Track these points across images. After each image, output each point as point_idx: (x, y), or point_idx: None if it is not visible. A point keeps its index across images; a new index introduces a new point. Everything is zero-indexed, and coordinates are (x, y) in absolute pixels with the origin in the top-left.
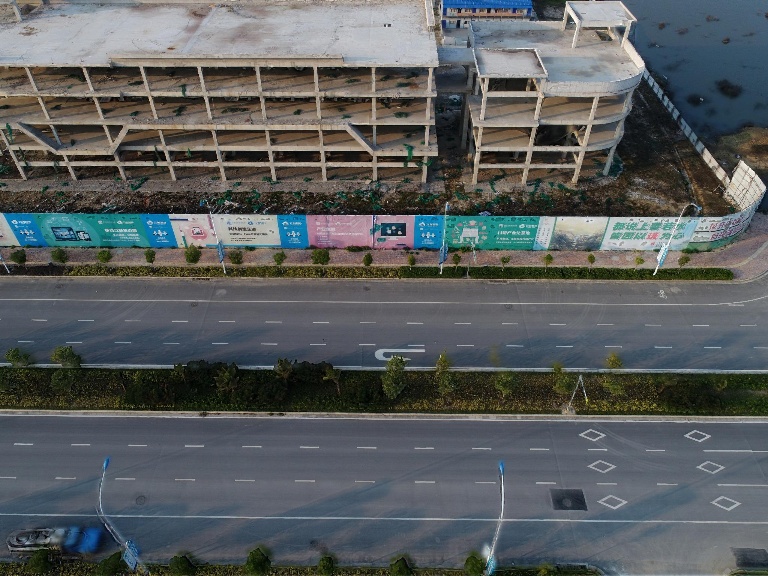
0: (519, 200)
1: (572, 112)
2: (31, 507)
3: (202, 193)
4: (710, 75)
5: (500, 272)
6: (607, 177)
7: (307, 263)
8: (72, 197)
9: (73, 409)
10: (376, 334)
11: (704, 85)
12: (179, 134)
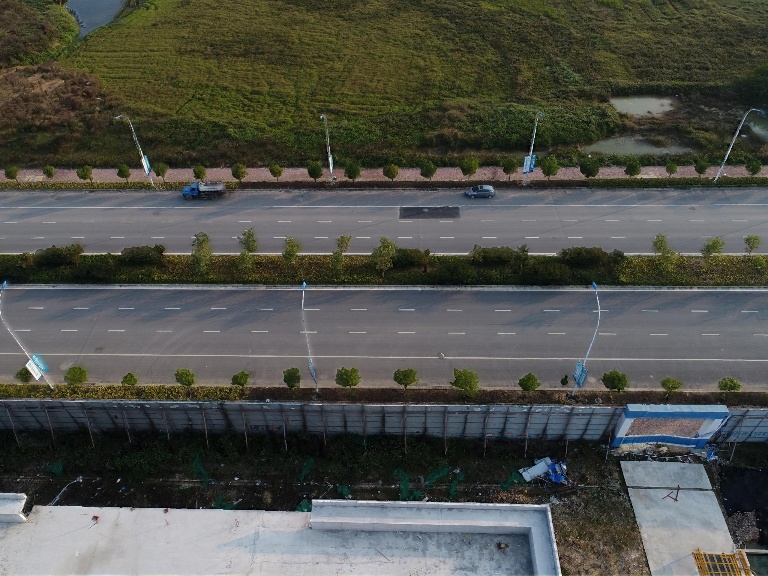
0: None
1: None
2: (223, 210)
3: None
4: None
5: None
6: None
7: None
8: None
9: None
10: None
11: None
12: None
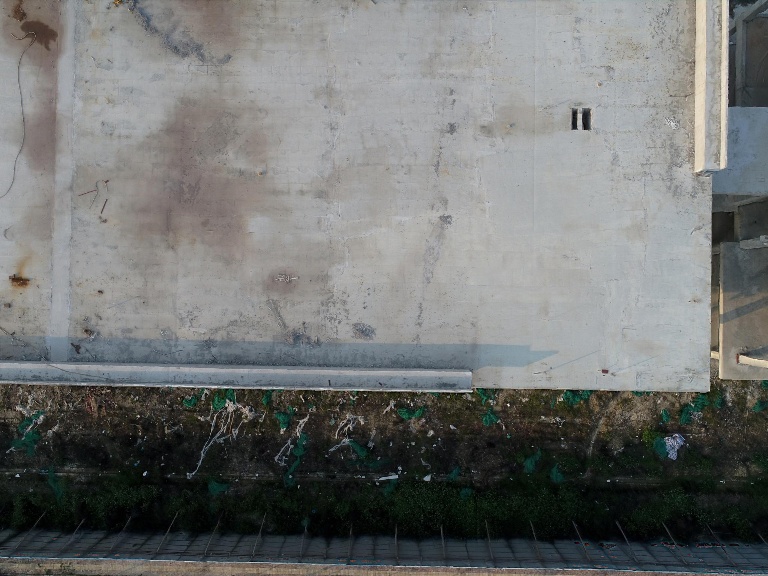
0: (740, 401)
1: None
2: None
3: None
4: None
5: None
6: None
7: (384, 571)
8: None
9: None
10: None
11: None
12: None
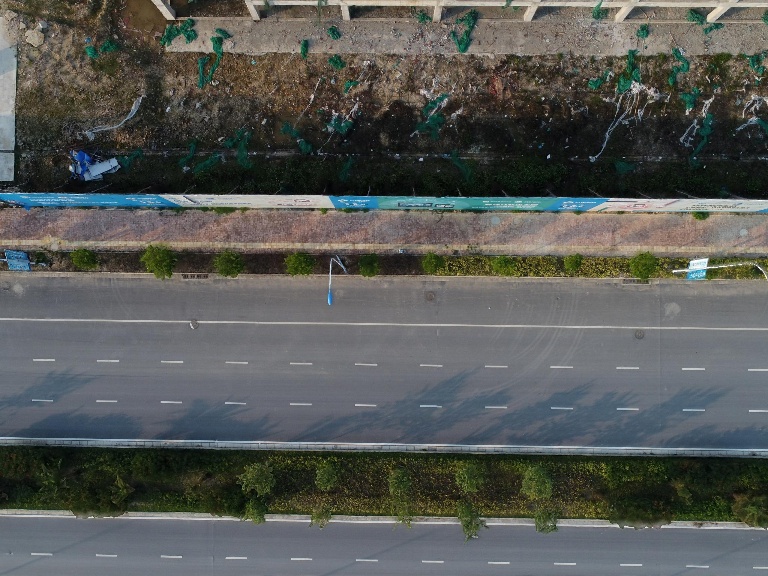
0: None
1: None
2: None
3: (586, 59)
4: None
5: None
6: None
7: None
8: (362, 73)
9: None
10: None
11: None
12: None
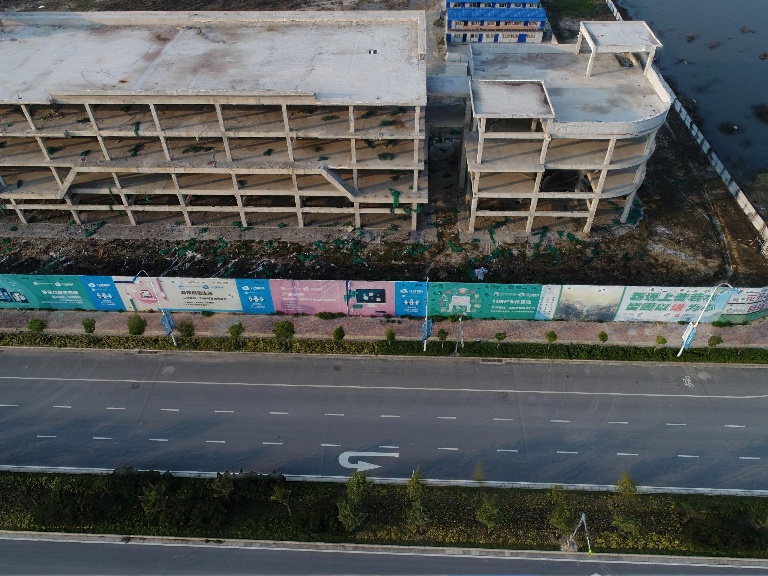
0: (522, 253)
1: (584, 154)
2: None
3: (163, 241)
4: (745, 98)
5: (494, 349)
6: (625, 225)
7: (271, 333)
8: (18, 245)
9: None
10: (343, 430)
11: (738, 110)
12: (138, 174)
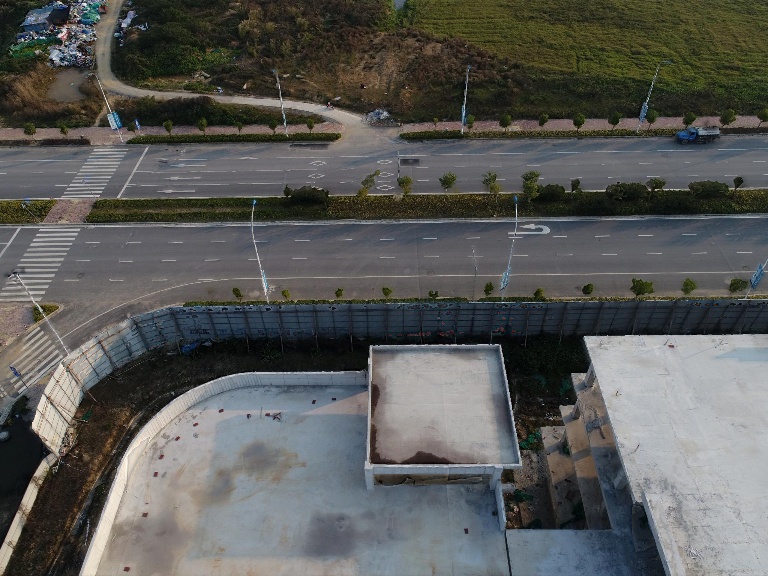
0: None
1: None
2: (727, 152)
3: None
4: None
5: None
6: None
7: None
8: None
9: (760, 190)
10: (554, 245)
11: None
12: None
